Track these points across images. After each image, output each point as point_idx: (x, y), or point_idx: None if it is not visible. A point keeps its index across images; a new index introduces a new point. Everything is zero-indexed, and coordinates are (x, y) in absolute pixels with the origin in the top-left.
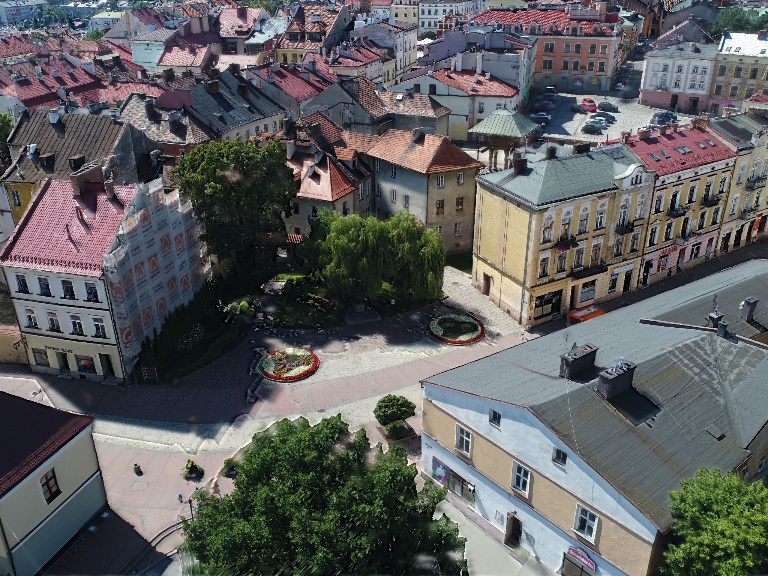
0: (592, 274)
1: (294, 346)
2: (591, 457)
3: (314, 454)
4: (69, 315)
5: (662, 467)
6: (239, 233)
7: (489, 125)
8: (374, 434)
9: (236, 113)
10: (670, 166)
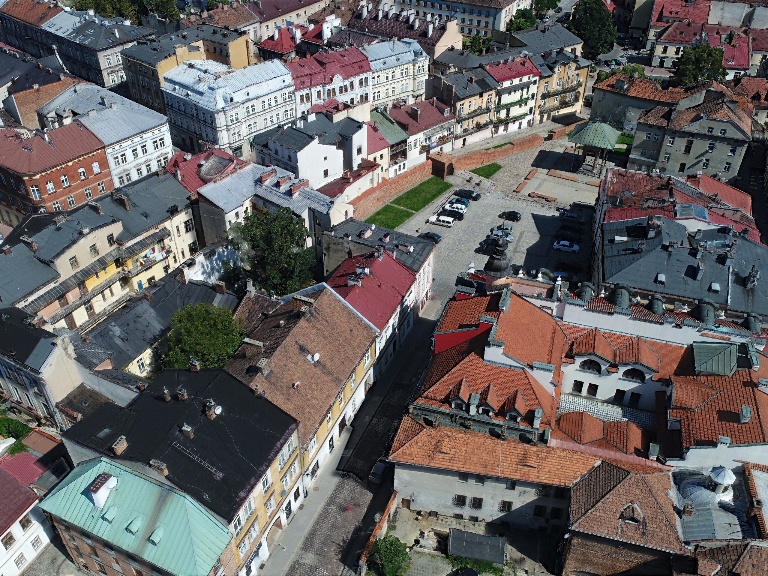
0: None
1: None
2: None
3: None
4: None
5: None
6: None
7: None
8: None
9: None
10: None
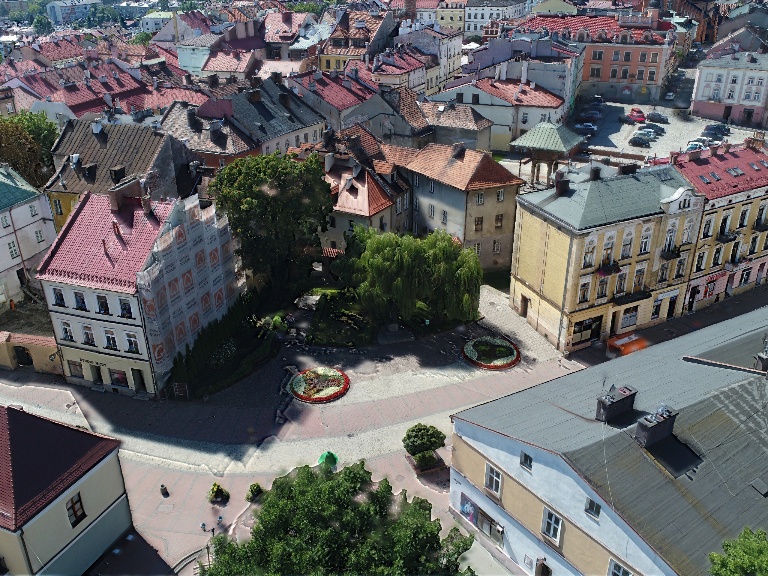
0: (634, 300)
1: (325, 365)
2: (626, 511)
3: (334, 508)
4: (103, 330)
5: (702, 525)
6: (274, 249)
7: (532, 138)
8: (402, 463)
9: (277, 122)
10: (721, 189)
